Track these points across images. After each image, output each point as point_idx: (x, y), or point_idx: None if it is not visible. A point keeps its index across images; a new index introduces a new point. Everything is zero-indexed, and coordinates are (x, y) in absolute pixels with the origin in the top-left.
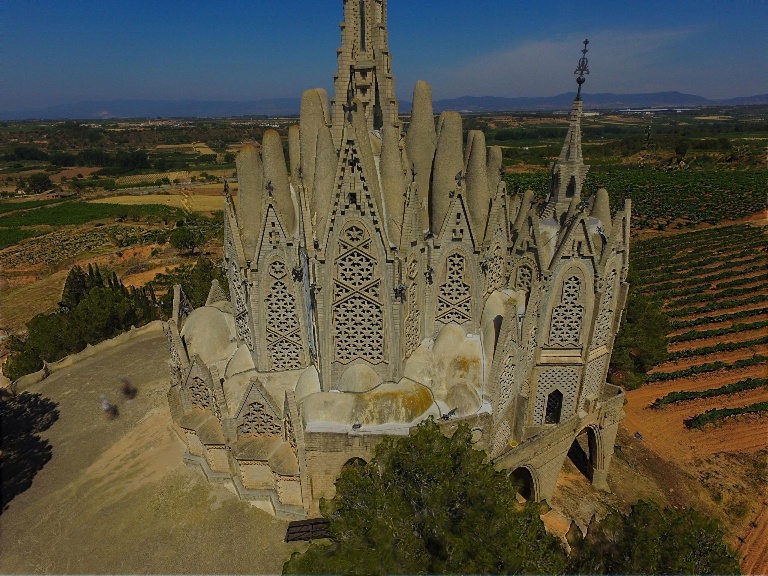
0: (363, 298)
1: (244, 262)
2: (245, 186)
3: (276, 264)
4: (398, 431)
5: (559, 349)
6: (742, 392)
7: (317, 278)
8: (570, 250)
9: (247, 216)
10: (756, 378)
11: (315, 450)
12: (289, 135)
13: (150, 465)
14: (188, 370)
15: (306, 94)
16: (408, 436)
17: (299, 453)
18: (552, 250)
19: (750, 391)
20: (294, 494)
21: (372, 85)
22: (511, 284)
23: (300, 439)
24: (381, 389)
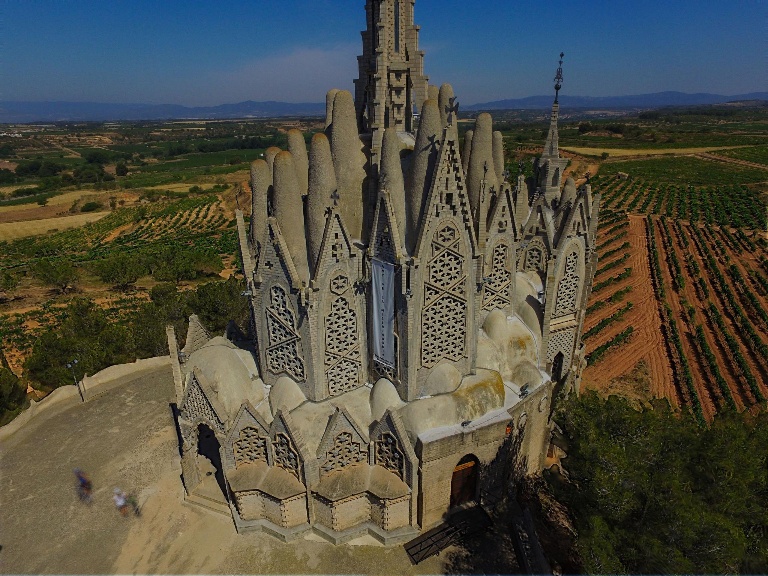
0: (451, 297)
1: (300, 282)
2: (285, 198)
3: (338, 279)
4: (502, 417)
5: (561, 316)
6: (600, 331)
7: (412, 284)
8: (571, 230)
9: (289, 231)
10: (601, 319)
11: (432, 460)
12: (290, 140)
13: (195, 552)
14: (235, 422)
15: (342, 95)
16: (512, 418)
17: (413, 469)
18: (552, 232)
19: (604, 329)
20: (401, 515)
21: (404, 87)
22: (520, 267)
23: (412, 454)
24: (467, 383)
